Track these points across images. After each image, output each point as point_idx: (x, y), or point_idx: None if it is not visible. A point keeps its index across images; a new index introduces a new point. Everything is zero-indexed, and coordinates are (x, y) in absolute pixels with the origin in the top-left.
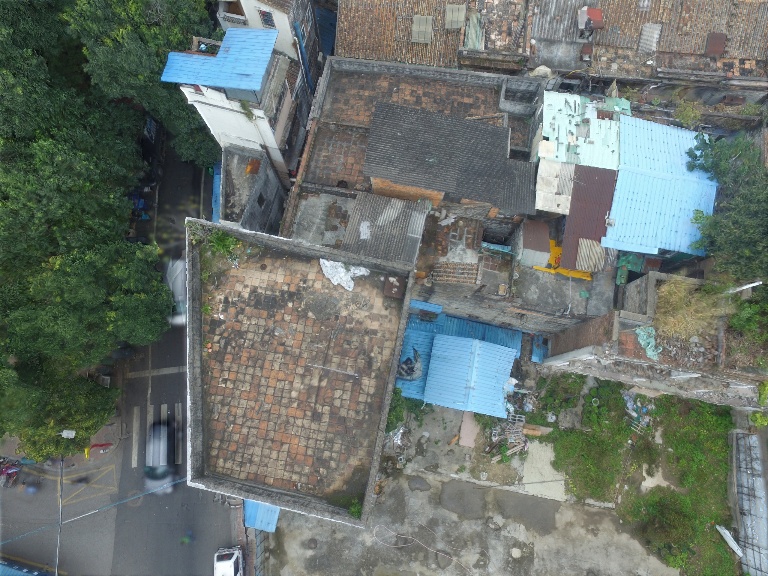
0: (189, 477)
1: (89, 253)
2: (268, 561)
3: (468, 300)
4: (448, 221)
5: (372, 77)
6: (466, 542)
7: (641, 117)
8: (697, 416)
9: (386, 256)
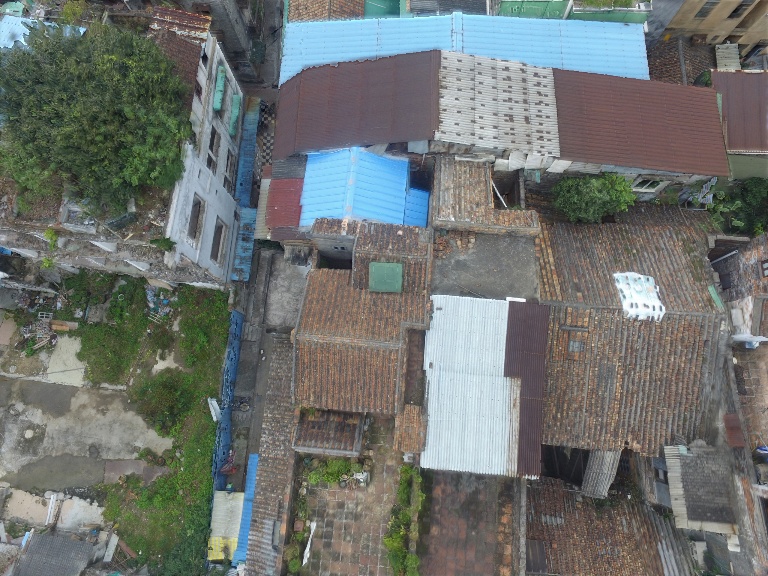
0: None
1: None
2: None
3: None
4: None
5: None
6: None
7: None
8: (209, 304)
9: None
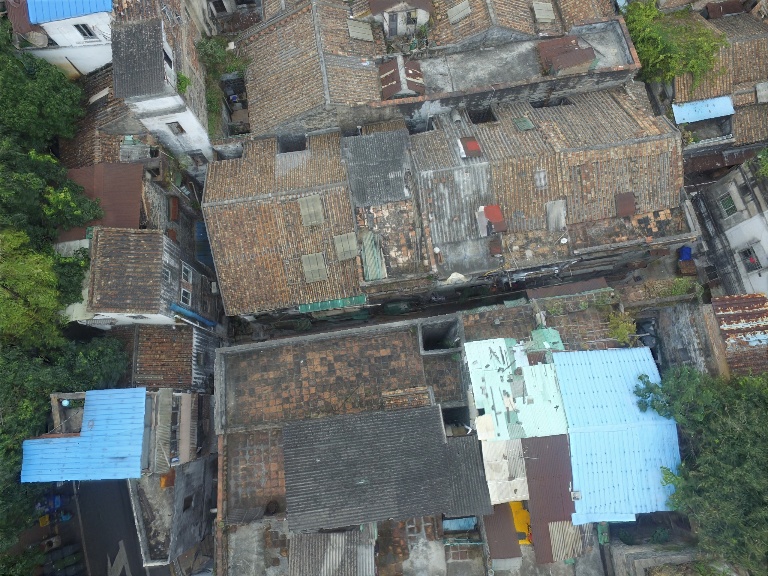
0: None
1: None
2: None
3: None
4: None
5: (273, 353)
6: None
7: (573, 320)
8: None
9: None
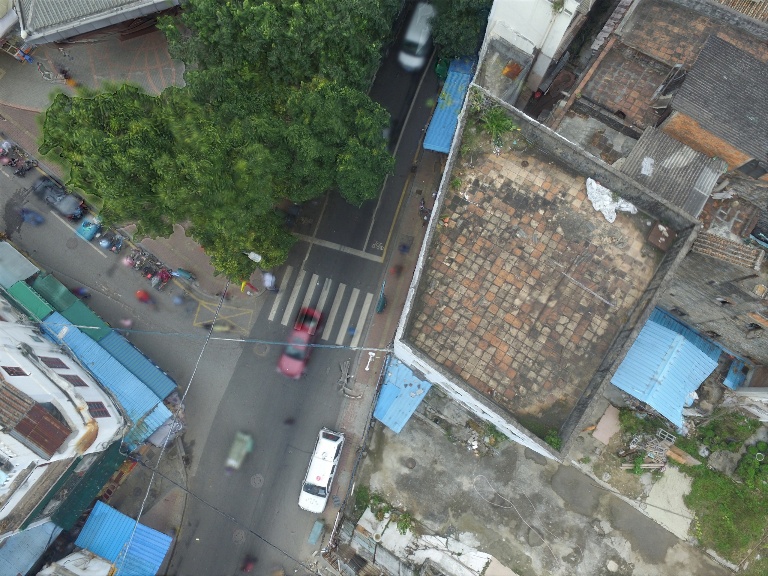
0: (399, 335)
1: (345, 89)
2: (363, 459)
3: (707, 288)
4: (724, 196)
5: (688, 15)
6: (564, 532)
7: None
8: None
9: None
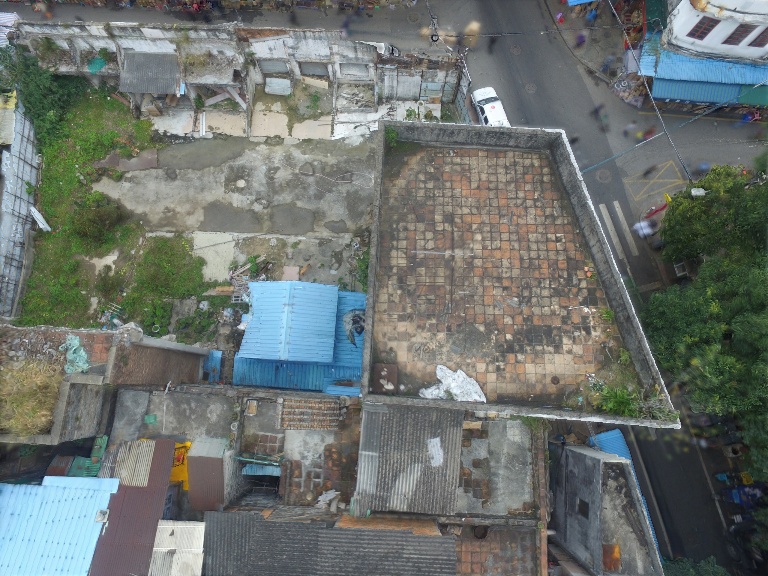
0: (564, 136)
1: None
2: None
3: None
4: (327, 496)
5: None
6: (287, 185)
7: None
8: None
9: (402, 416)
